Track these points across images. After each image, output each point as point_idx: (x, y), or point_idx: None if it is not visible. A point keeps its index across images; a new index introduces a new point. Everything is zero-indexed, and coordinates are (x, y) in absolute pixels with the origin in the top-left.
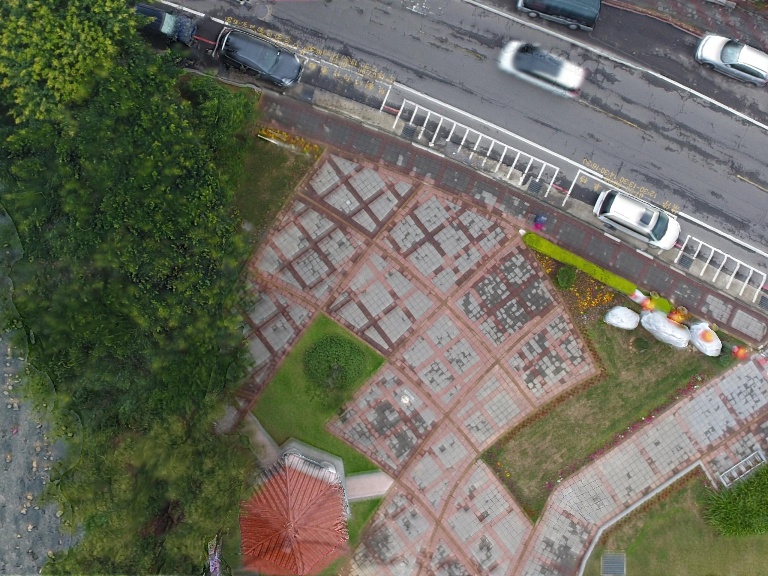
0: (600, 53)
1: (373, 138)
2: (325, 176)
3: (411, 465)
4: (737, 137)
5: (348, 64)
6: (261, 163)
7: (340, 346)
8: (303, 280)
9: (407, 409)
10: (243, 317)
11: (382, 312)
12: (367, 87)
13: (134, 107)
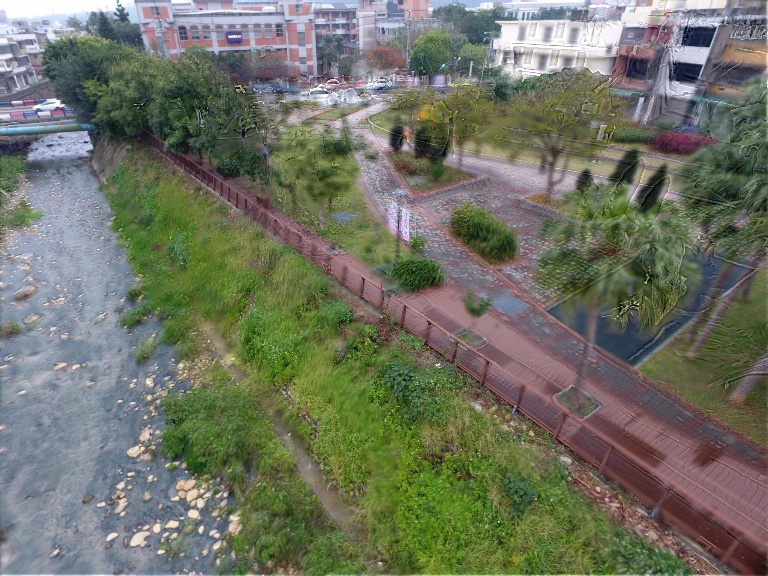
0: None
1: None
2: None
3: None
4: None
5: None
6: None
7: None
8: None
9: None
10: None
11: None
12: None
13: None
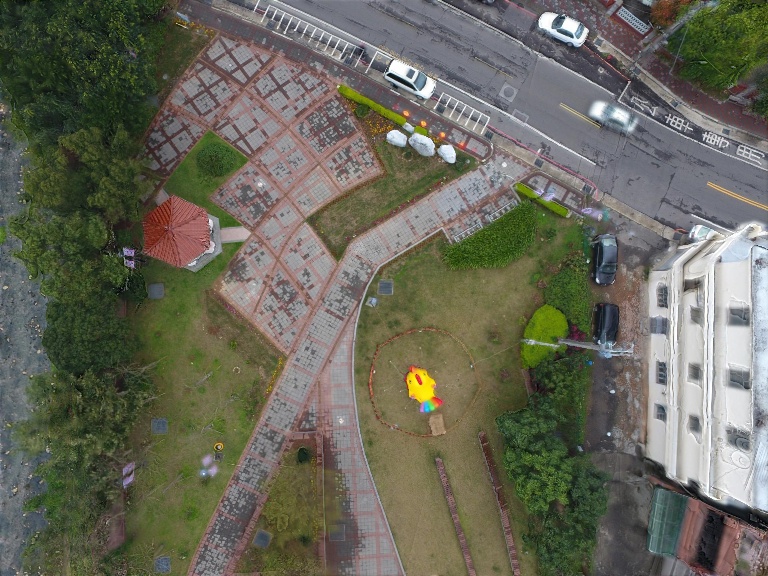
0: None
1: (248, 27)
2: (217, 49)
3: (262, 224)
4: (476, 34)
5: None
6: (177, 40)
7: (219, 149)
8: (199, 111)
9: (261, 191)
10: (161, 132)
11: (248, 132)
12: None
13: None
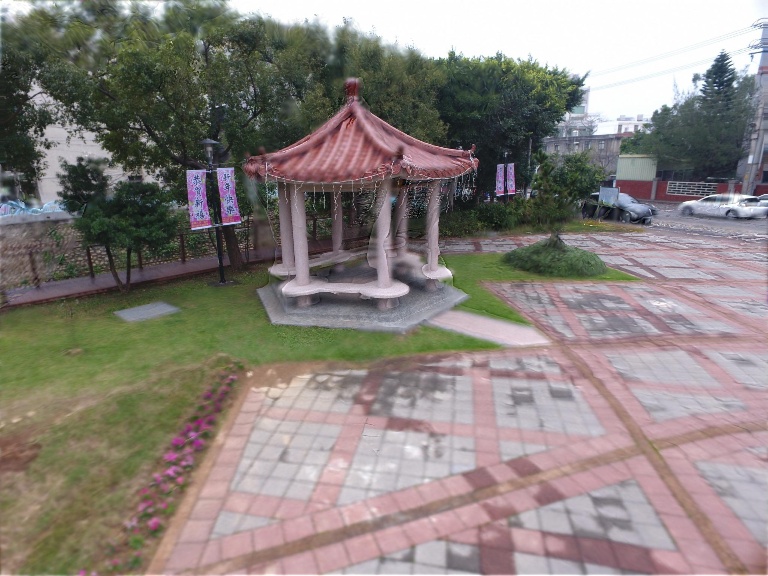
0: None
1: None
2: None
3: (614, 344)
4: None
5: None
6: None
7: None
8: None
9: (653, 308)
10: None
11: (661, 266)
12: None
13: None
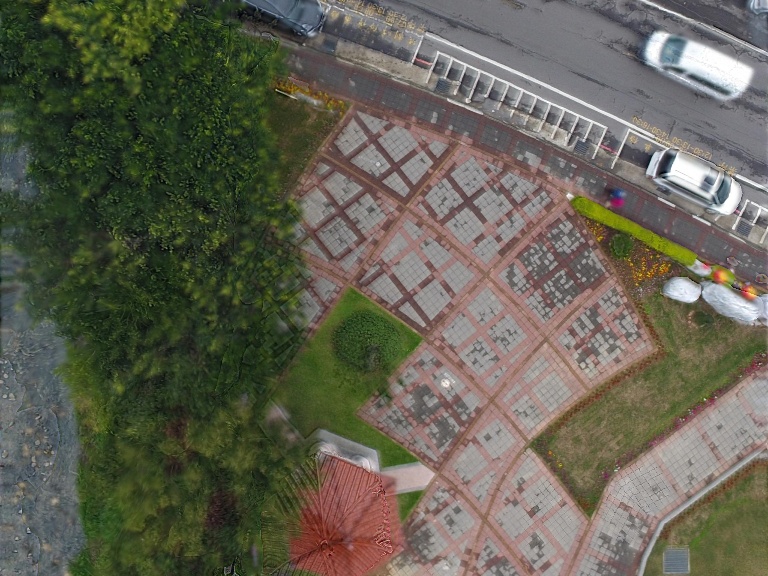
0: (648, 3)
1: (404, 93)
2: (351, 135)
3: (453, 456)
4: None
5: (374, 12)
6: (279, 120)
7: (372, 324)
8: (328, 251)
9: (447, 394)
10: (261, 293)
11: (417, 286)
12: (396, 38)
13: (113, 8)
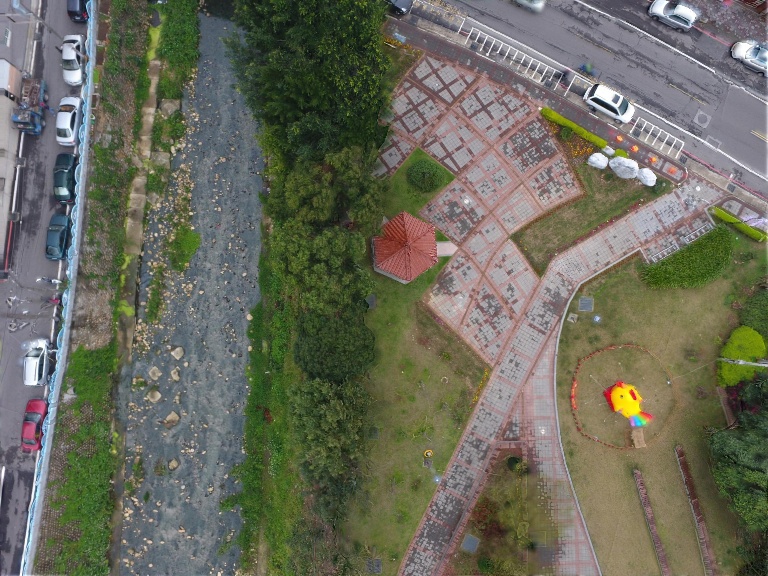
0: (591, 7)
1: (453, 48)
2: (423, 69)
3: (468, 240)
4: (670, 61)
5: (439, 4)
6: None
7: (430, 166)
8: (408, 128)
9: (467, 207)
10: None
11: (455, 150)
12: (450, 19)
13: None
